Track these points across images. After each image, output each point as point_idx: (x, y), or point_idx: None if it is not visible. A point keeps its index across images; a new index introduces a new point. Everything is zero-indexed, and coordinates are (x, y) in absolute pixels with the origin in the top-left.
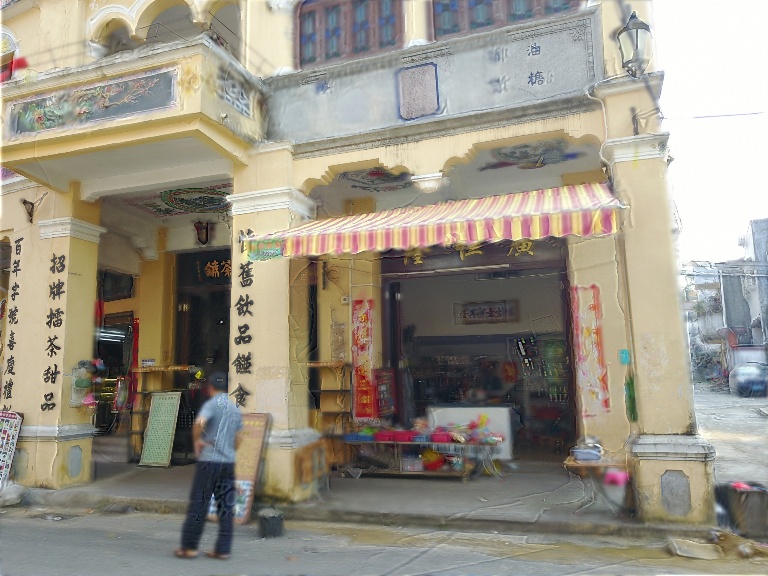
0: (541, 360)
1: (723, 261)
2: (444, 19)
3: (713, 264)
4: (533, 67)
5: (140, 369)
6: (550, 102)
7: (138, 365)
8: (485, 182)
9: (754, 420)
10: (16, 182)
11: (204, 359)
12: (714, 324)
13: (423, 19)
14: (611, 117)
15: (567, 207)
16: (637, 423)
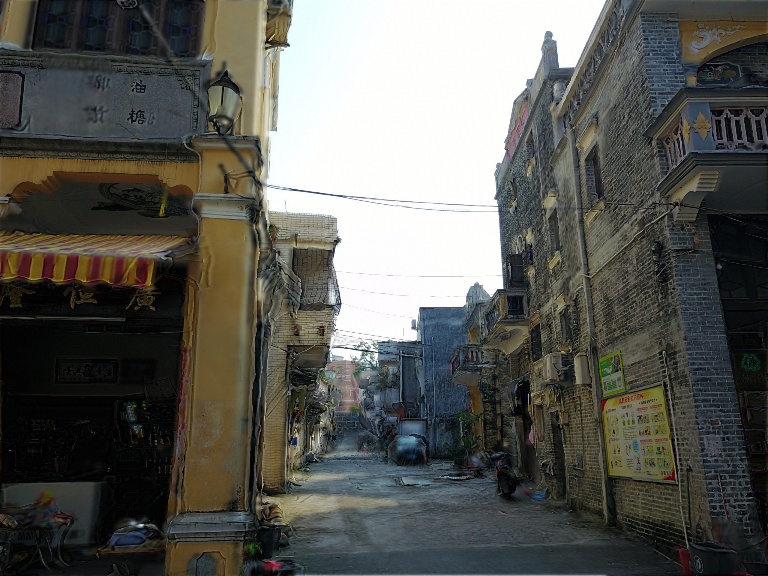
0: (153, 427)
1: (384, 340)
2: (48, 31)
3: (376, 342)
4: (135, 104)
5: None
6: (146, 144)
7: None
8: (100, 223)
9: (388, 489)
10: None
11: None
12: (392, 399)
13: (20, 23)
14: (205, 171)
15: (105, 250)
16: (183, 500)
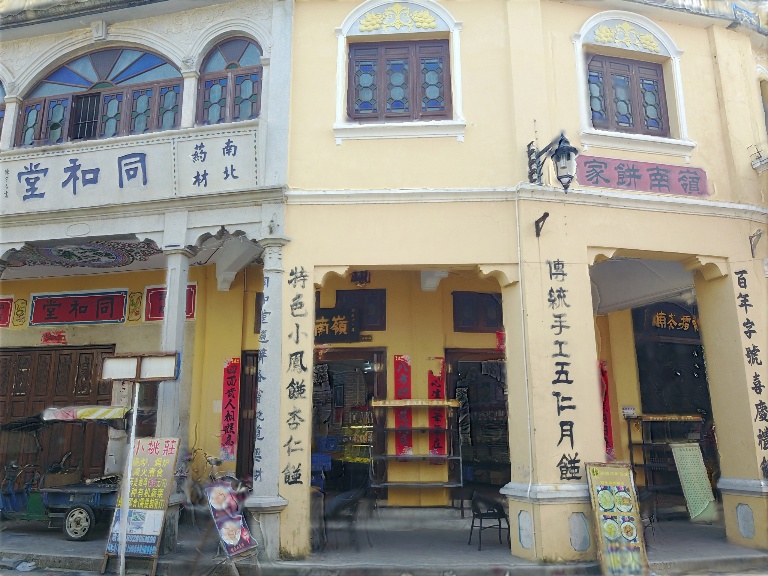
0: None
1: None
2: None
3: None
4: None
5: (651, 418)
6: None
7: (618, 413)
8: None
9: None
10: (733, 208)
11: (696, 410)
12: None
13: None
14: None
15: None
16: None
